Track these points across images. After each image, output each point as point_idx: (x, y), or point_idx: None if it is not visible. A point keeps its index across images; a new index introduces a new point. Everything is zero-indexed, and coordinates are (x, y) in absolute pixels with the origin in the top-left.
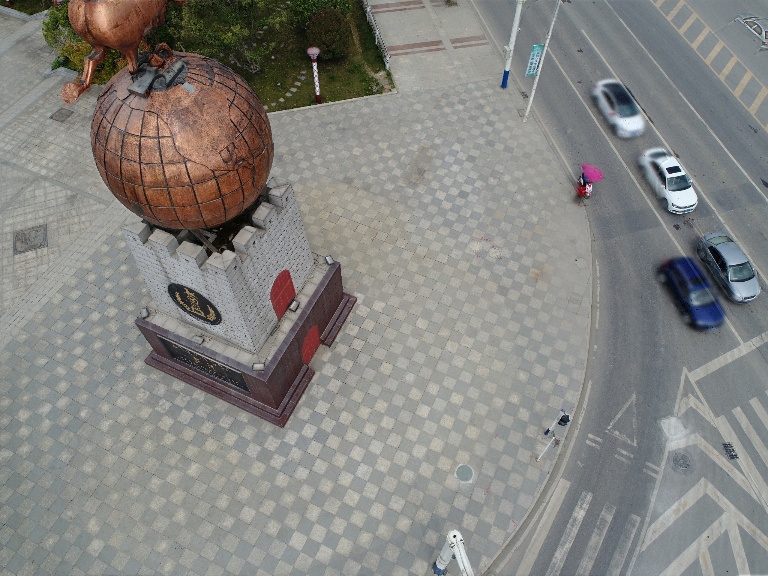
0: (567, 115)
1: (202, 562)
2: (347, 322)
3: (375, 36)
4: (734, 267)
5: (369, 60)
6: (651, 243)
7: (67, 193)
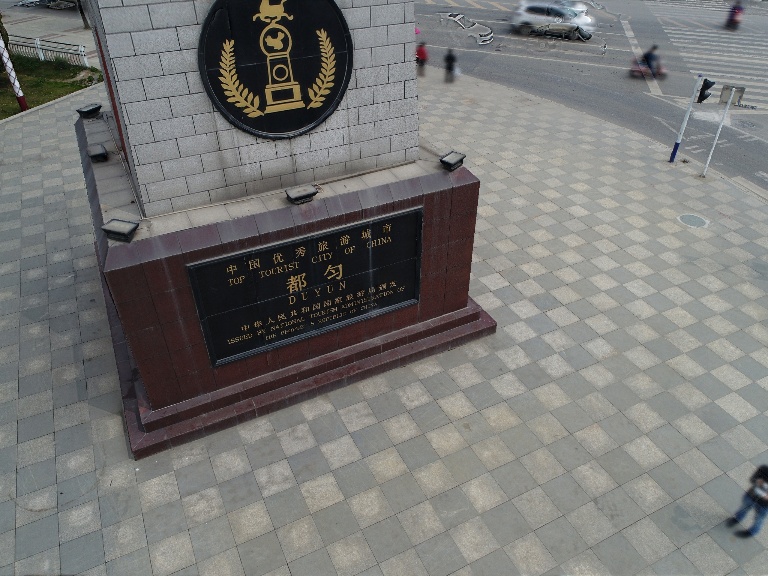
0: None
1: None
2: None
3: (35, 52)
4: (577, 31)
5: (49, 74)
6: (501, 61)
7: None
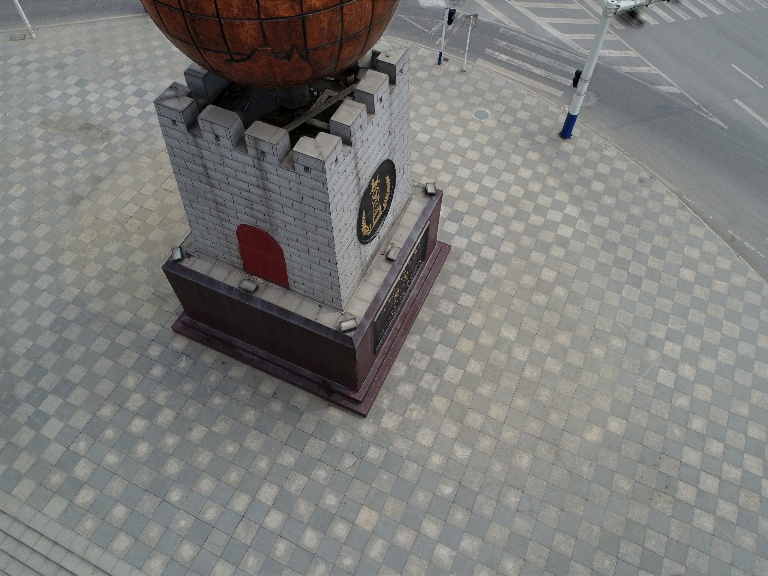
0: (39, 7)
1: (604, 311)
2: None
3: None
4: None
5: None
6: None
7: None
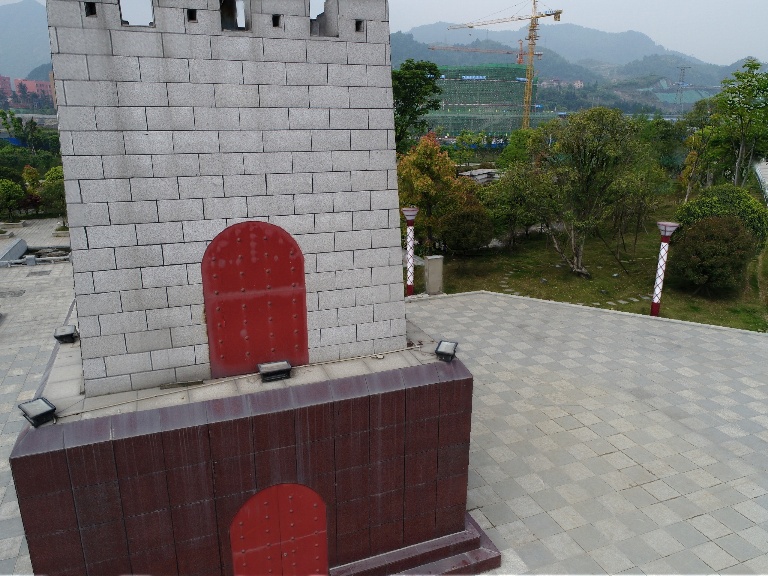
0: None
1: None
2: None
3: None
4: None
5: None
6: None
7: None
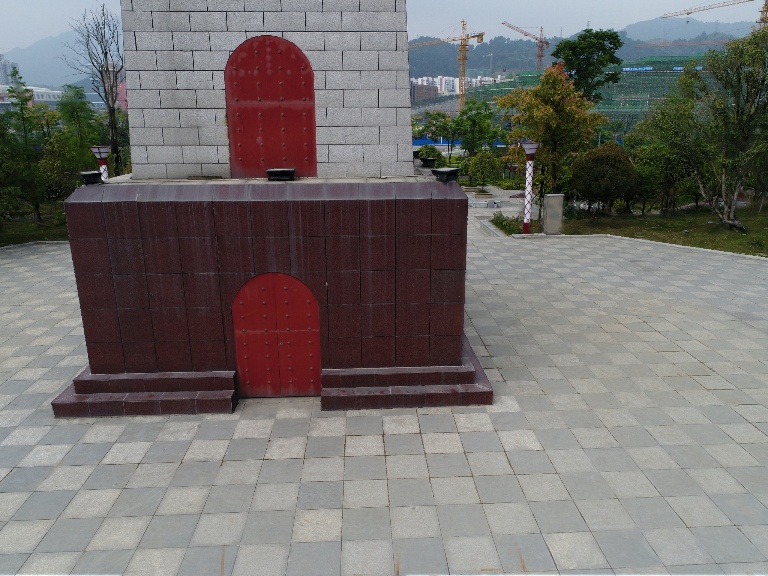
0: None
1: None
2: (416, 410)
3: None
4: None
5: None
6: None
7: None
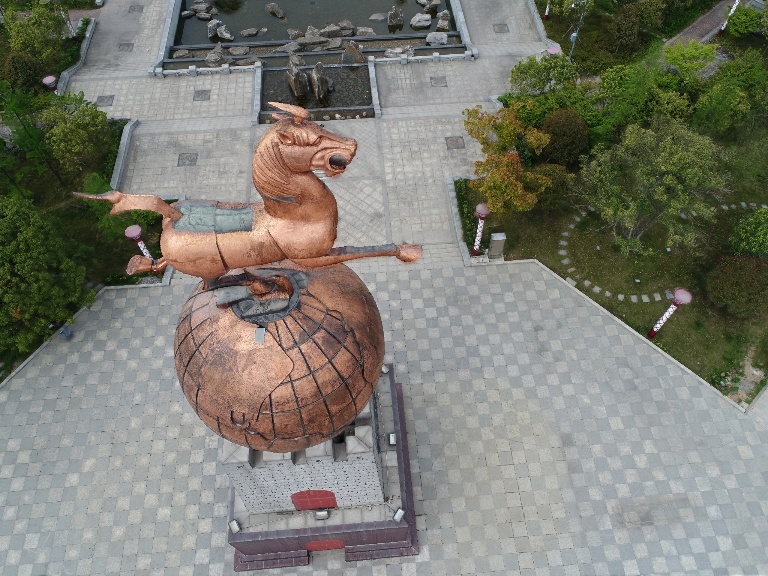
0: None
1: None
2: (386, 561)
3: None
4: None
5: (765, 345)
6: None
7: (380, 208)
